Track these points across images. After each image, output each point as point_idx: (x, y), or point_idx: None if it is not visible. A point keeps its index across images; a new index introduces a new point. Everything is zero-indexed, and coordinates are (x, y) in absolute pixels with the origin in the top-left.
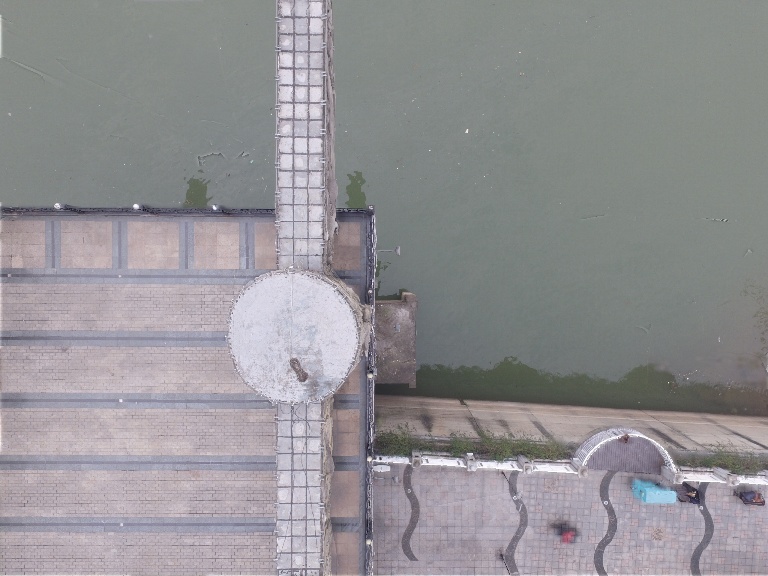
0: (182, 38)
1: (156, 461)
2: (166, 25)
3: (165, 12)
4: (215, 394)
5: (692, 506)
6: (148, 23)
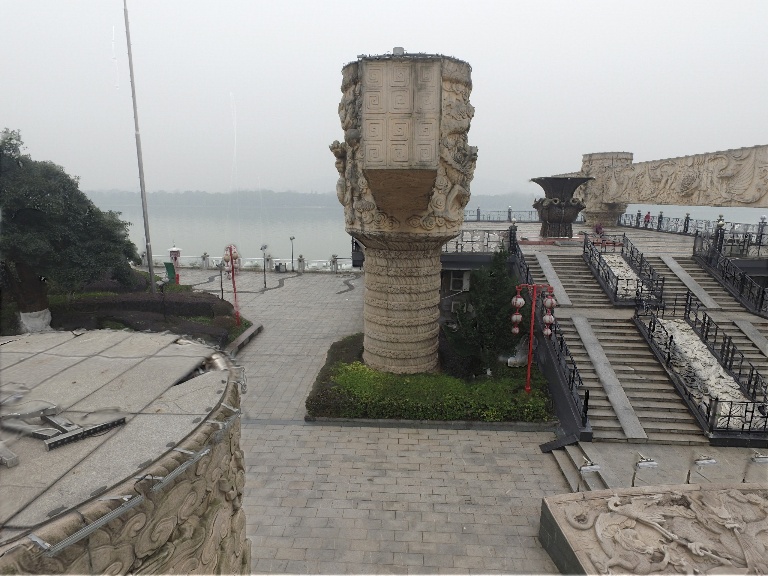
0: (515, 202)
1: None
2: (513, 197)
3: (516, 191)
4: None
5: None
6: (506, 198)
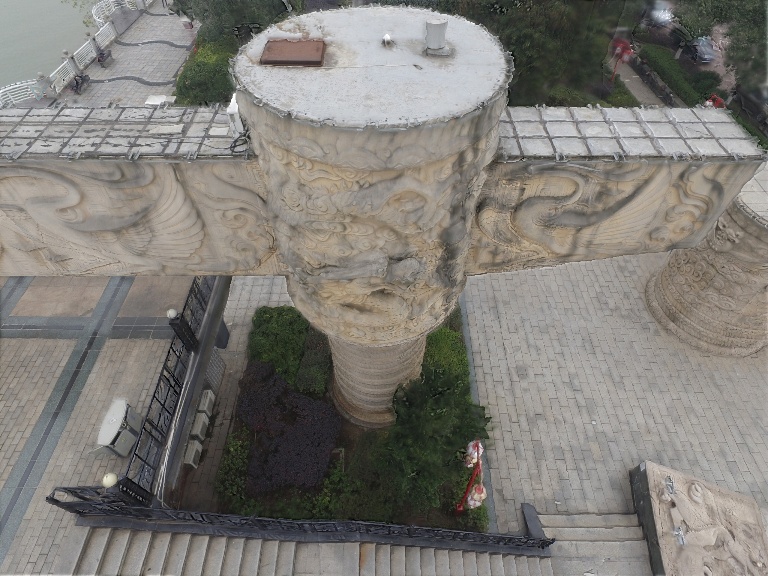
0: None
1: None
2: None
3: None
4: None
5: (101, 85)
6: None
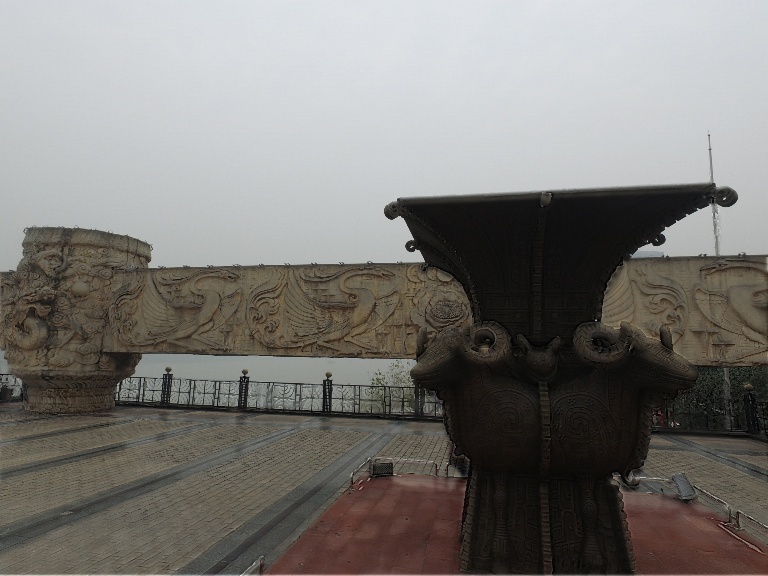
0: None
1: (9, 471)
2: None
3: None
4: (18, 437)
5: None
6: None
